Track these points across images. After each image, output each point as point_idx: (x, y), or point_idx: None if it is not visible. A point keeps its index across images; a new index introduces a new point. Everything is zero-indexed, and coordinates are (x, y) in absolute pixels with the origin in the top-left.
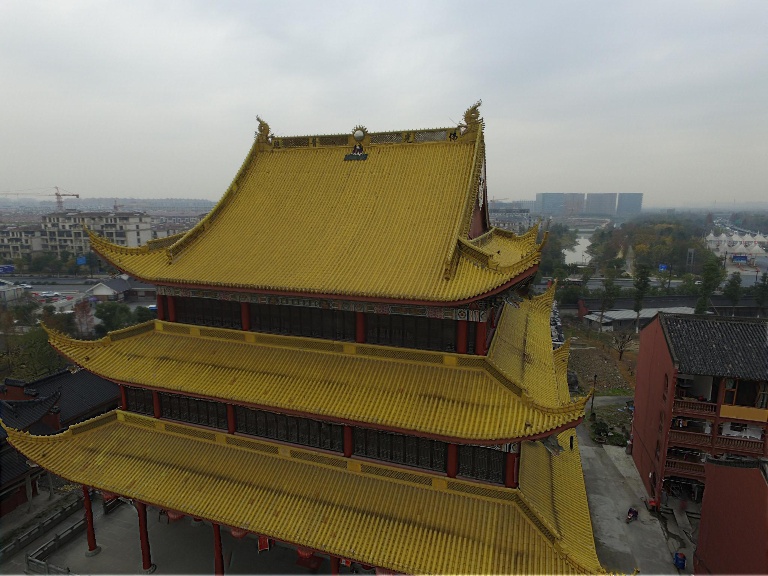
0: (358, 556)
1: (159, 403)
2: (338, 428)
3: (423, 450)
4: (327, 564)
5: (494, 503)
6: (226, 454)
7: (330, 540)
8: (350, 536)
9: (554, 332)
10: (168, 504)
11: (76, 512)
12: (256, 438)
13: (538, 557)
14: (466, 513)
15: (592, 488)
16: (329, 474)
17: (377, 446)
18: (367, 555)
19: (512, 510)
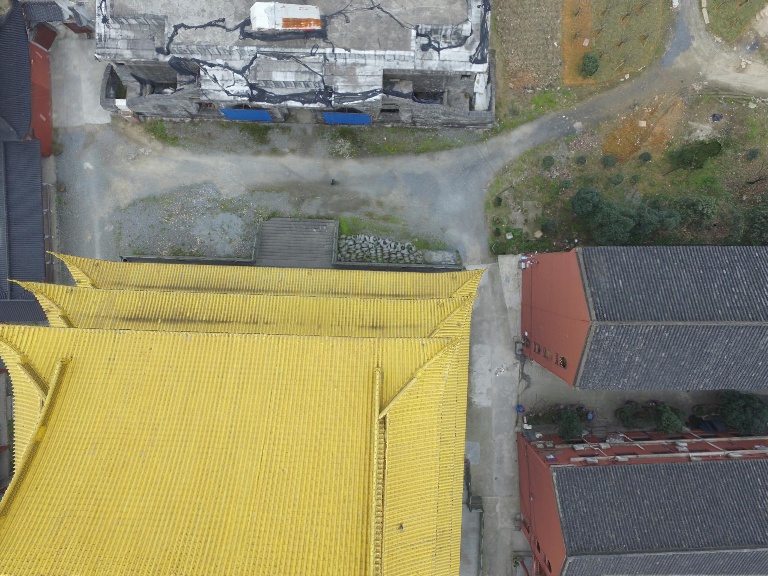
0: None
1: None
2: None
3: None
4: None
5: None
6: None
7: None
8: None
9: (476, 6)
10: None
11: None
12: None
13: None
14: None
15: (477, 336)
16: None
17: None
18: None
19: None
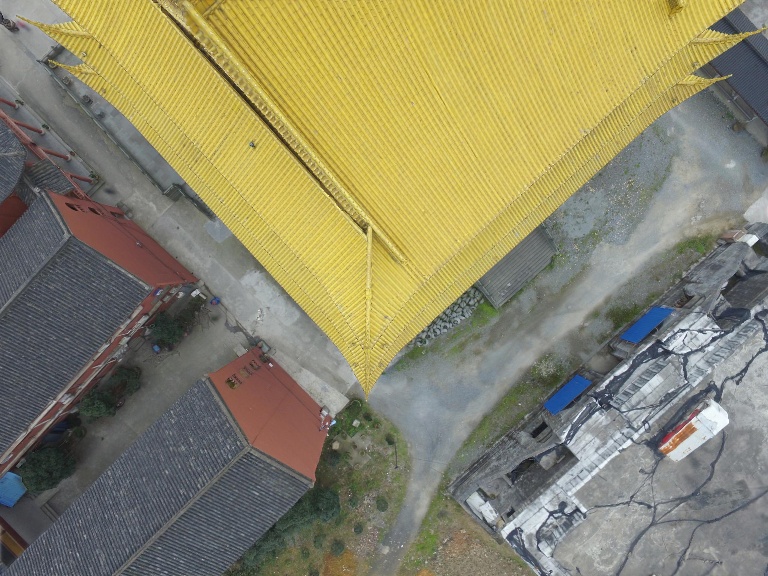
0: None
1: None
2: None
3: None
4: None
5: None
6: None
7: None
8: None
9: (554, 571)
10: None
11: None
12: None
13: None
14: None
15: (305, 324)
16: None
17: None
18: None
19: None
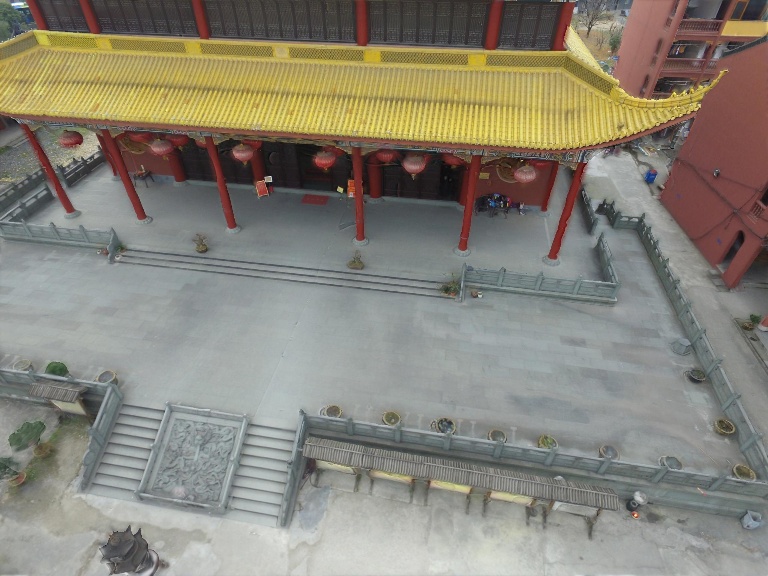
0: (396, 135)
1: (91, 10)
2: (348, 7)
3: (458, 21)
4: (334, 200)
5: (538, 73)
6: (205, 66)
7: (361, 126)
8: (382, 121)
9: None
10: (152, 119)
11: (32, 190)
12: (240, 40)
13: (590, 110)
14: (508, 86)
15: None
16: (342, 70)
17: (399, 26)
18: (406, 133)
19: (559, 76)
